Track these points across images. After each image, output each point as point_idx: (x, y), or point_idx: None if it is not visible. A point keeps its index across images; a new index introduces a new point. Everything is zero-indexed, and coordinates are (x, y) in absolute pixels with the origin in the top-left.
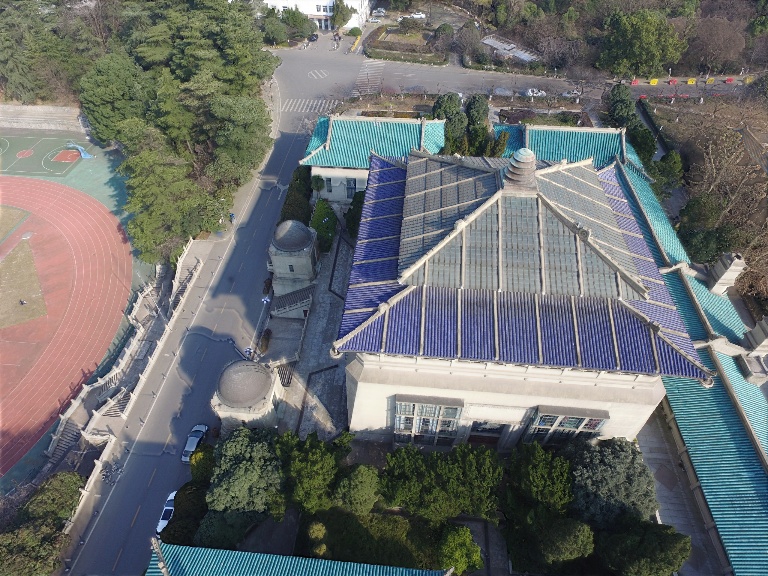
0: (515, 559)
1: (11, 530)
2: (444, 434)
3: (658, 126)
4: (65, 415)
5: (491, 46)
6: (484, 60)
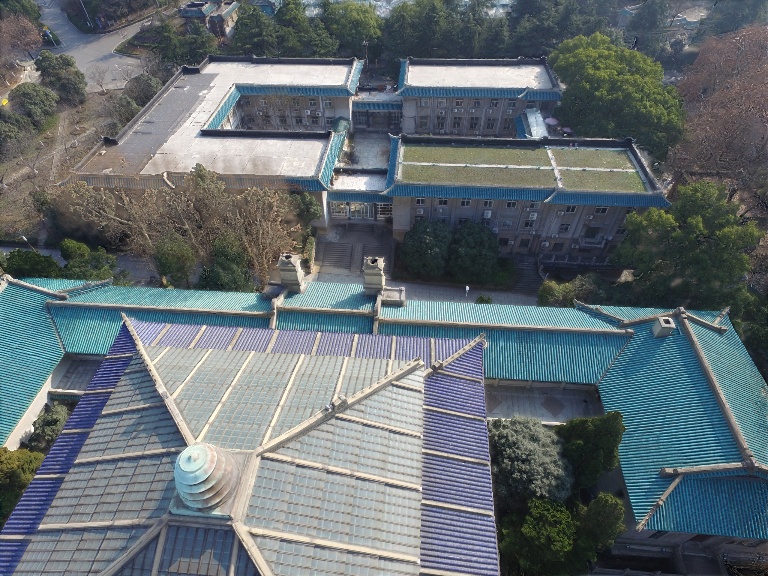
0: (579, 575)
1: None
2: None
3: None
4: None
5: None
6: None
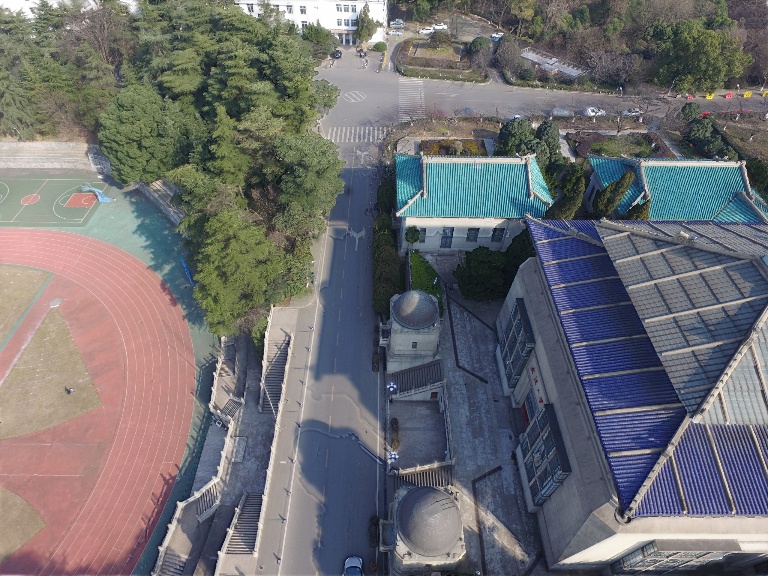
0: None
1: None
2: (684, 567)
3: (736, 146)
4: (163, 545)
5: (531, 60)
6: (528, 76)
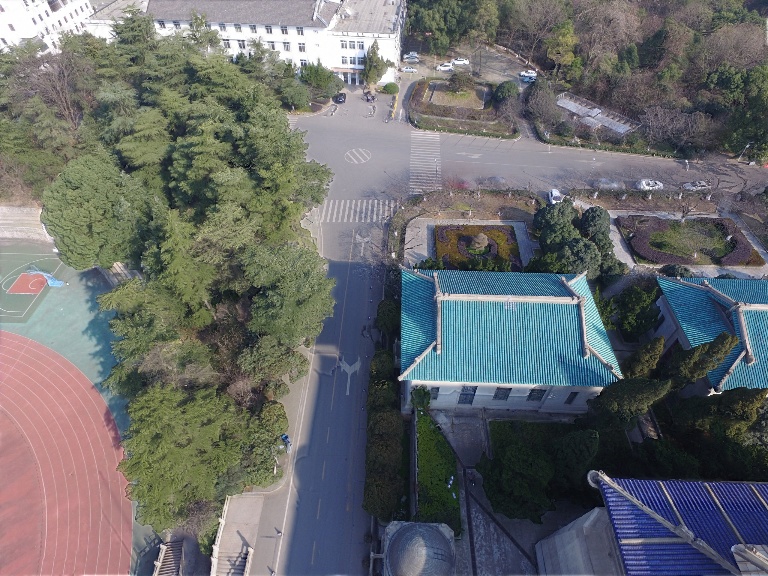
0: None
1: None
2: None
3: None
4: None
5: (569, 110)
6: (566, 132)
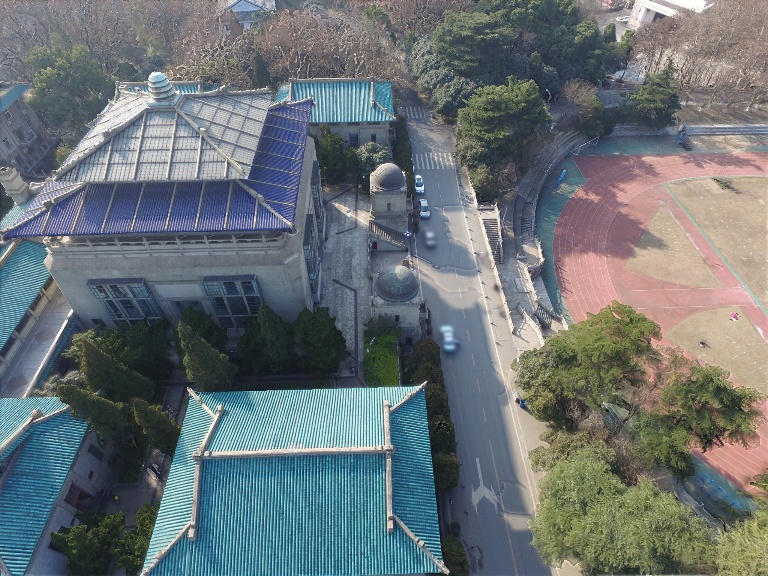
0: None
1: (490, 165)
2: None
3: None
4: None
5: None
6: None
